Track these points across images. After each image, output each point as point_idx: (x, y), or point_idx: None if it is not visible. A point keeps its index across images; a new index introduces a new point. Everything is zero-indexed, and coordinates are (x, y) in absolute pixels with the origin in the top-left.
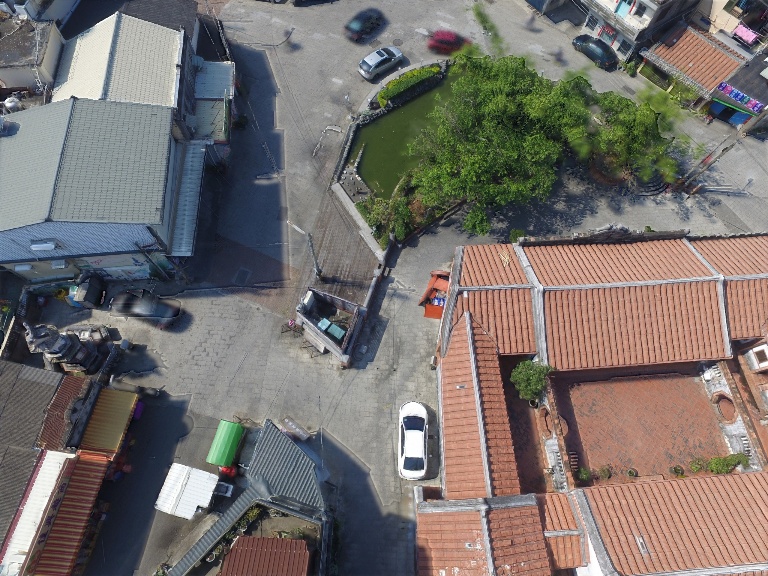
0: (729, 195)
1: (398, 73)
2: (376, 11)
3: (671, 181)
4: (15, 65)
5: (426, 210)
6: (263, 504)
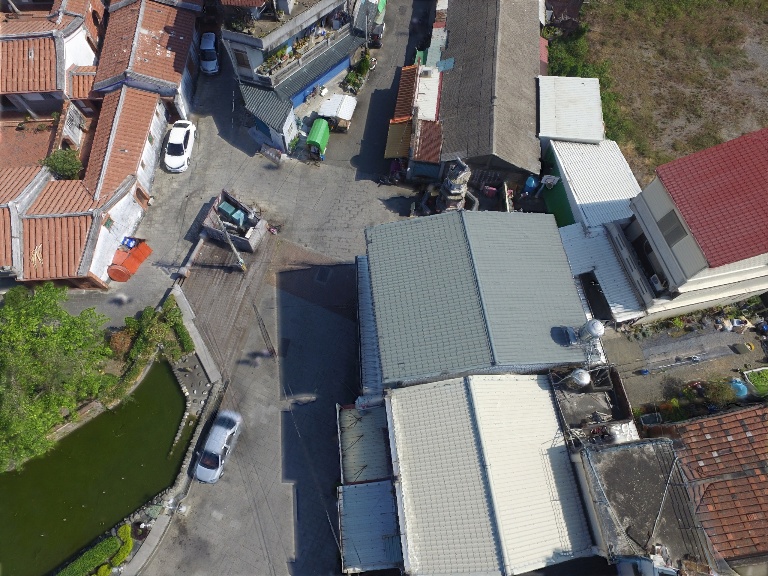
0: None
1: None
2: None
3: None
4: (613, 447)
5: None
6: (256, 37)
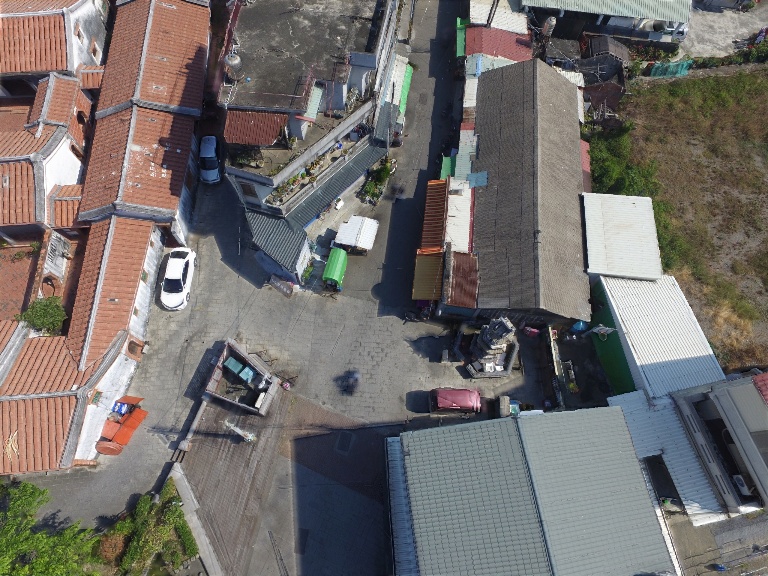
0: None
1: None
2: None
3: None
4: None
5: None
6: (266, 176)
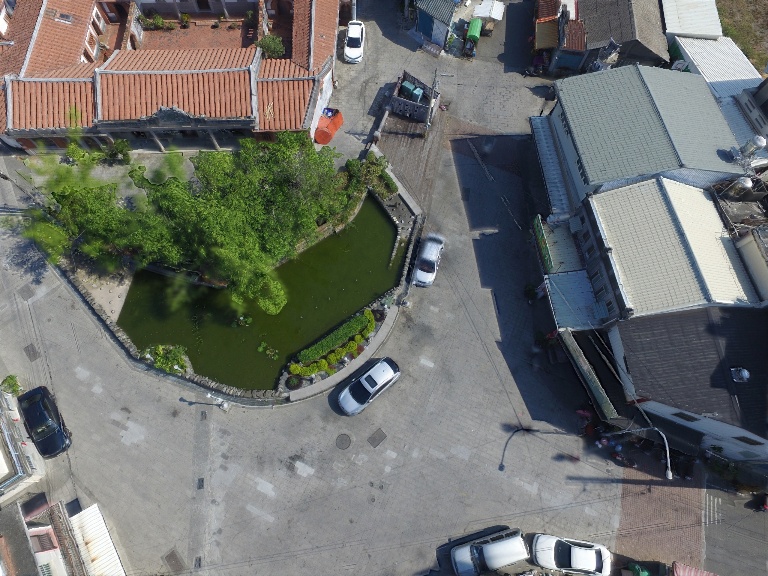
0: (4, 205)
1: (347, 371)
2: (375, 520)
3: None
4: None
5: None
6: None
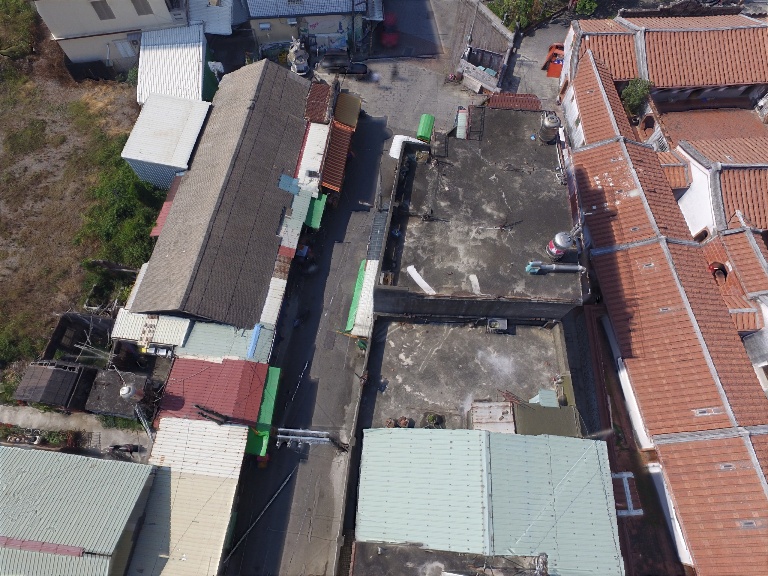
0: (767, 4)
1: None
2: None
3: None
4: None
5: (539, 11)
6: None
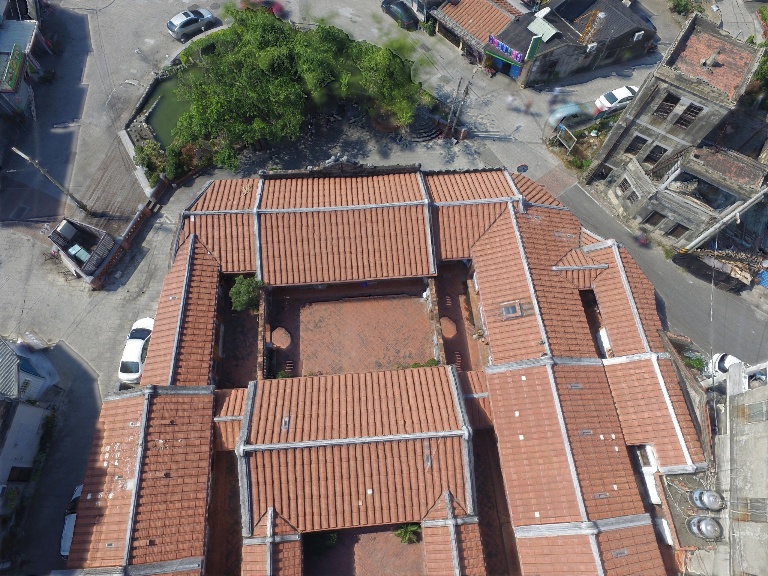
0: (495, 140)
1: (206, 33)
2: None
3: (443, 128)
4: None
5: (202, 153)
6: None
